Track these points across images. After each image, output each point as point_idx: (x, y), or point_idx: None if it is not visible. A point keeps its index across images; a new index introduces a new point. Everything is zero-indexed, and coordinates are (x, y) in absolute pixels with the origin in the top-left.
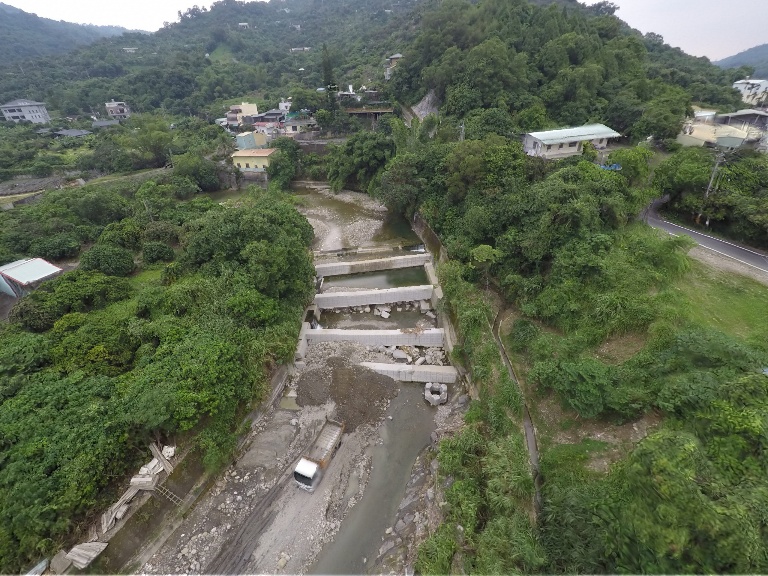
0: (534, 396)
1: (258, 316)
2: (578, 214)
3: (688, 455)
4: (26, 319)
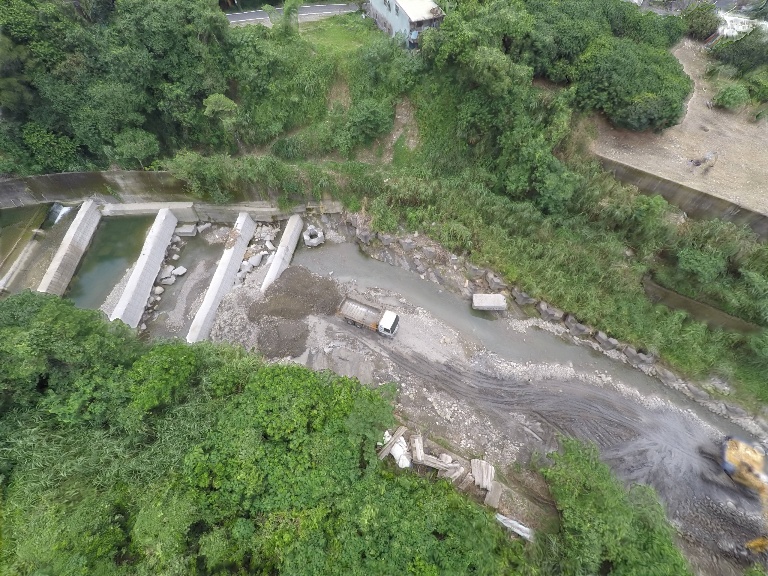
0: None
1: None
2: (218, 22)
3: None
4: None
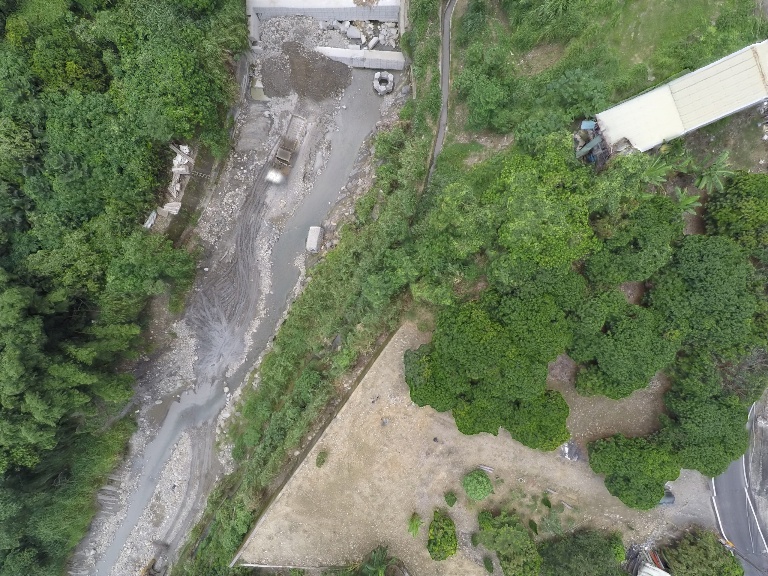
0: (456, 98)
1: (196, 5)
2: None
3: (462, 196)
4: None
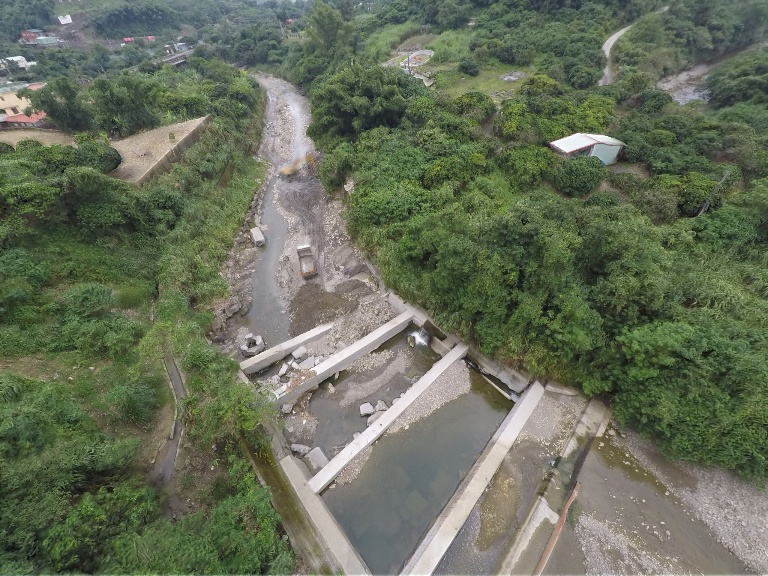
0: None
1: None
2: None
3: None
4: None
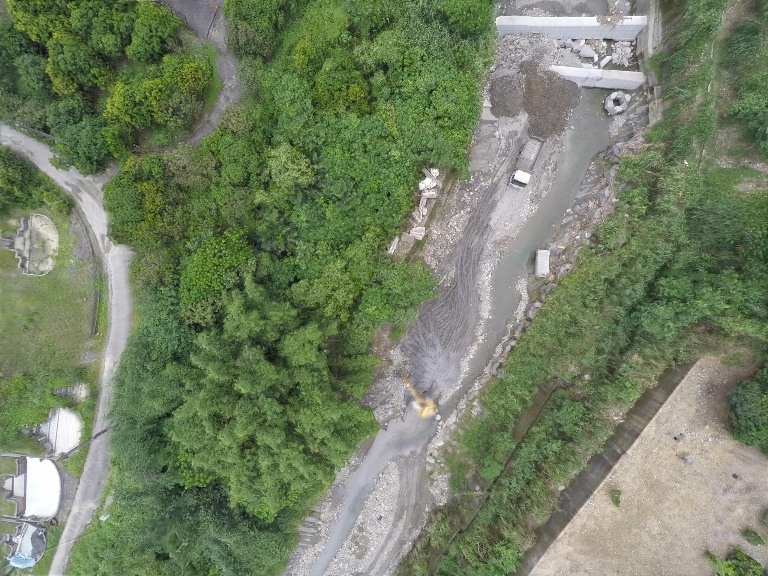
0: (719, 121)
1: (475, 25)
2: None
3: None
4: (254, 47)
